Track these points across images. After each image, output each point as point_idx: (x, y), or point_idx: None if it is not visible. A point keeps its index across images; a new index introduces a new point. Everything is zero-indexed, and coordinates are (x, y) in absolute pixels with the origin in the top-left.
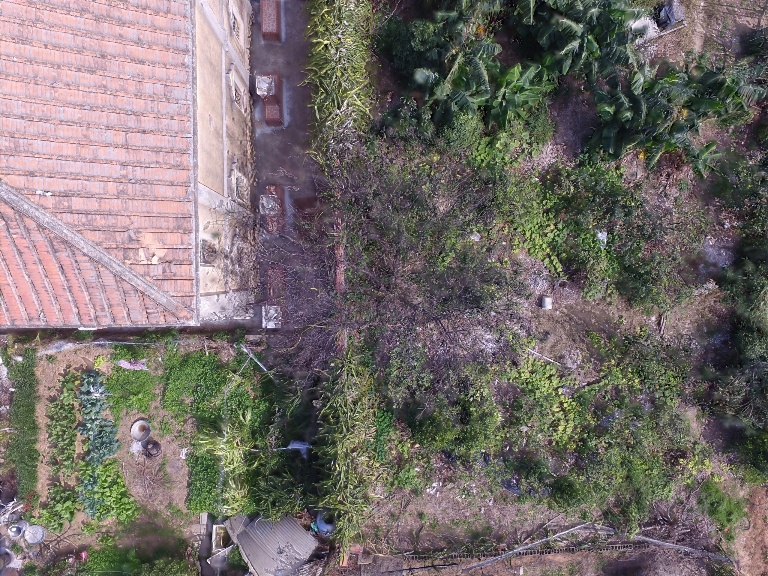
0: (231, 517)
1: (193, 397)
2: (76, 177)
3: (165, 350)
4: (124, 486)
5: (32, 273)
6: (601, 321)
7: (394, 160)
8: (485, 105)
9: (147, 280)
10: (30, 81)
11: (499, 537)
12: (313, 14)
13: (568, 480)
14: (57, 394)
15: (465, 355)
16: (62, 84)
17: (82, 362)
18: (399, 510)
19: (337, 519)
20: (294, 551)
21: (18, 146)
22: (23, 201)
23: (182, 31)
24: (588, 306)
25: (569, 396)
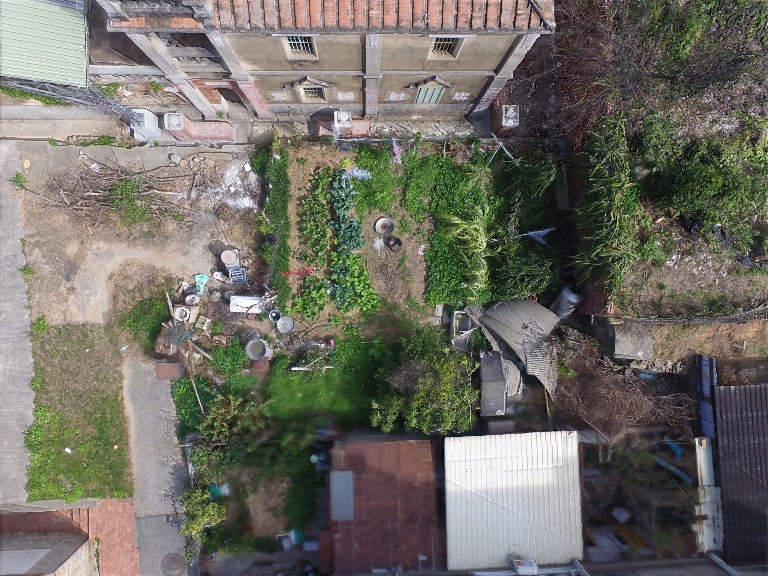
0: (468, 306)
1: (430, 197)
2: None
3: (406, 153)
4: None
5: None
6: None
7: None
8: None
9: None
10: None
11: (735, 303)
12: None
13: None
14: (307, 194)
15: (705, 135)
16: None
17: (329, 164)
18: (641, 281)
19: (612, 264)
20: (537, 327)
21: None
22: None
23: None
24: None
25: None
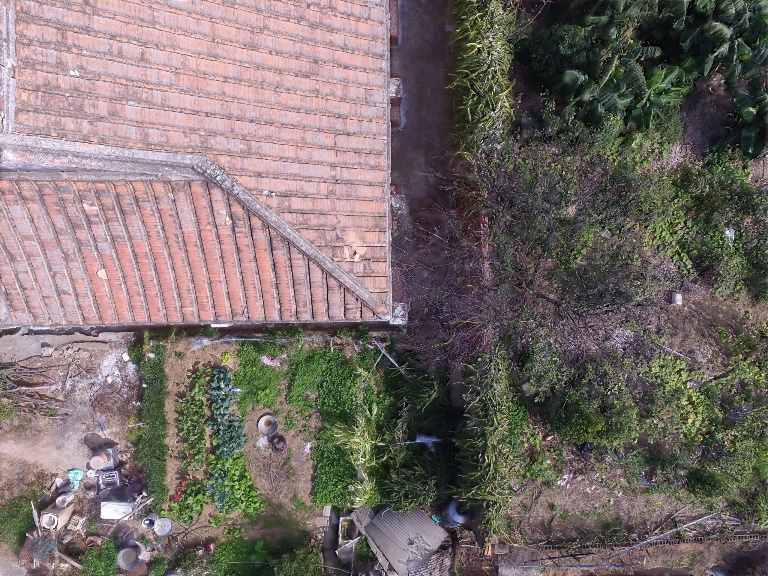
0: (356, 509)
1: (317, 392)
2: (294, 178)
3: (291, 347)
4: (251, 479)
5: (245, 270)
6: (728, 316)
7: (527, 160)
8: (628, 106)
9: (351, 277)
10: (258, 86)
11: (629, 528)
12: (463, 18)
13: (707, 471)
14: (186, 390)
15: (597, 350)
16: (283, 88)
17: (210, 359)
18: (531, 502)
19: (486, 509)
20: (424, 542)
21: (250, 148)
22: (255, 201)
23: (380, 36)
24: (716, 302)
25: (696, 390)
